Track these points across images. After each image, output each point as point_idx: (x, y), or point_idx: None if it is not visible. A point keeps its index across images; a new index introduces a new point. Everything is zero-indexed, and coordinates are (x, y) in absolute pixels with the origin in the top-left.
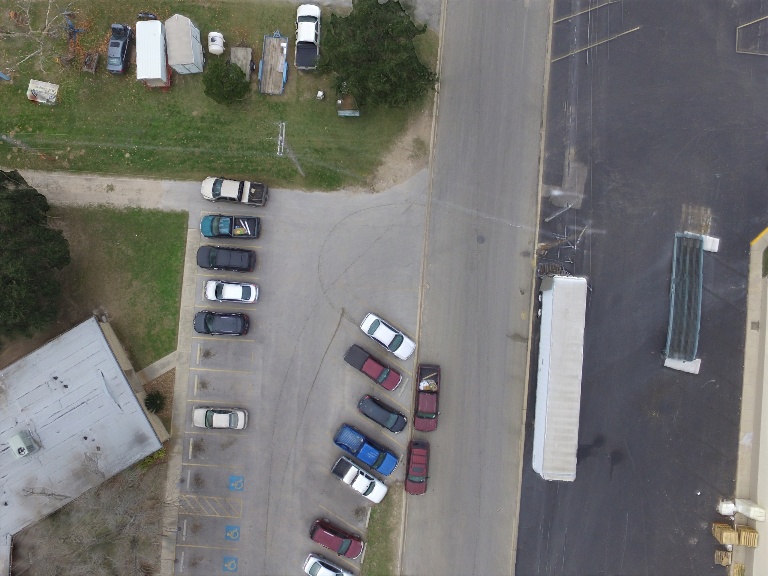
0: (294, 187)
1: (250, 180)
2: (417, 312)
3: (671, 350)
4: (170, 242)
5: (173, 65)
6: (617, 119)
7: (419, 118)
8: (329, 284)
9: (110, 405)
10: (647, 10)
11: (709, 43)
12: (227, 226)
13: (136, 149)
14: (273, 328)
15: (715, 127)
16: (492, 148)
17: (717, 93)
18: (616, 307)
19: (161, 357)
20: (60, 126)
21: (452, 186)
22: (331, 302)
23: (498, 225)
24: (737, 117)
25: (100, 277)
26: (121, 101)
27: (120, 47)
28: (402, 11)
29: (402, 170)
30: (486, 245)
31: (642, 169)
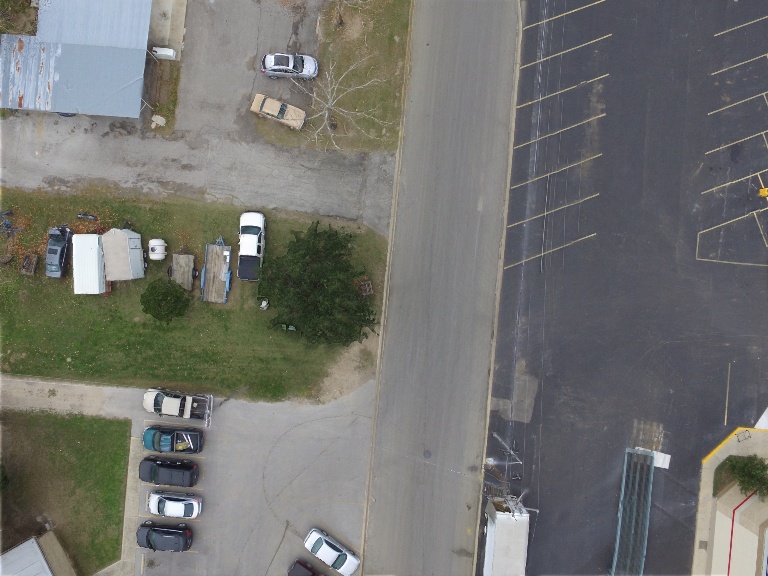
0: (238, 397)
1: (194, 388)
2: (362, 526)
3: (616, 574)
4: (113, 451)
5: (111, 280)
6: (570, 330)
7: (366, 328)
8: (274, 496)
9: None
10: (605, 215)
11: (668, 250)
12: (168, 445)
13: (77, 354)
14: (217, 539)
15: (671, 339)
16: (441, 360)
17: (674, 303)
18: (563, 524)
19: (105, 566)
20: None
21: (399, 398)
22: (276, 514)
23: (445, 440)
24: (694, 328)
25: (43, 484)
26: (61, 304)
27: (58, 254)
28: (342, 250)
29: (348, 381)
30: (433, 460)
31: (594, 382)
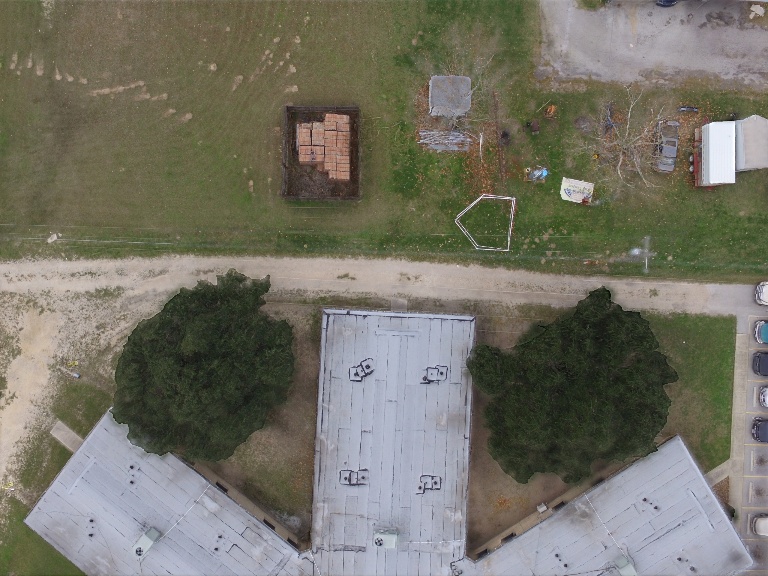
0: None
1: None
2: None
3: None
4: (720, 348)
5: None
6: None
7: None
8: None
9: (704, 525)
10: None
11: None
12: None
13: (680, 251)
14: None
15: None
16: None
17: None
18: None
19: (715, 466)
20: (598, 228)
21: None
22: None
23: None
24: None
25: None
26: (663, 201)
27: (676, 146)
28: None
29: None
30: None
31: None
